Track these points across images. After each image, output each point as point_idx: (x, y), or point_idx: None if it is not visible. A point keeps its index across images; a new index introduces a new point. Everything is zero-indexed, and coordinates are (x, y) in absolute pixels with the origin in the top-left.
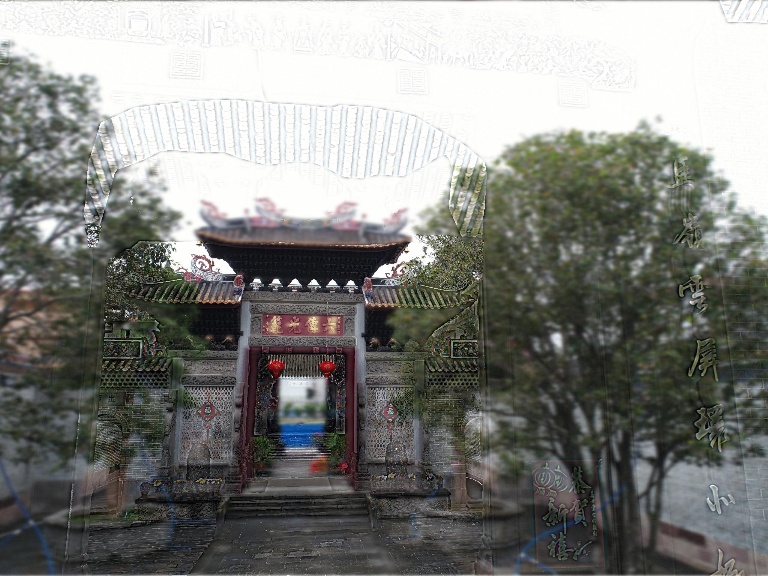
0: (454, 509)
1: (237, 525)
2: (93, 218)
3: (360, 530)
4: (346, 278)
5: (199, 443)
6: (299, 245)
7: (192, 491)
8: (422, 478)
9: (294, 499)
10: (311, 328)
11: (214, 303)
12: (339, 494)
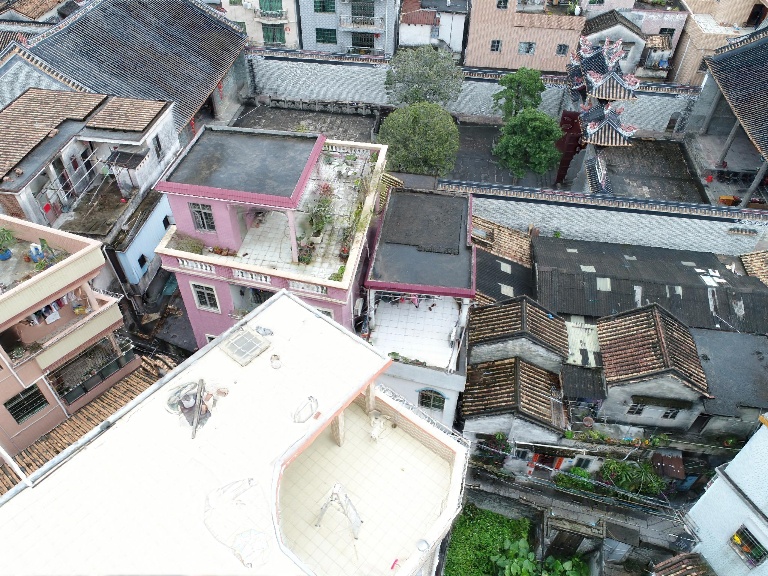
0: None
1: None
2: None
3: None
4: None
5: None
6: None
7: None
8: None
9: None
10: None
11: None
12: None
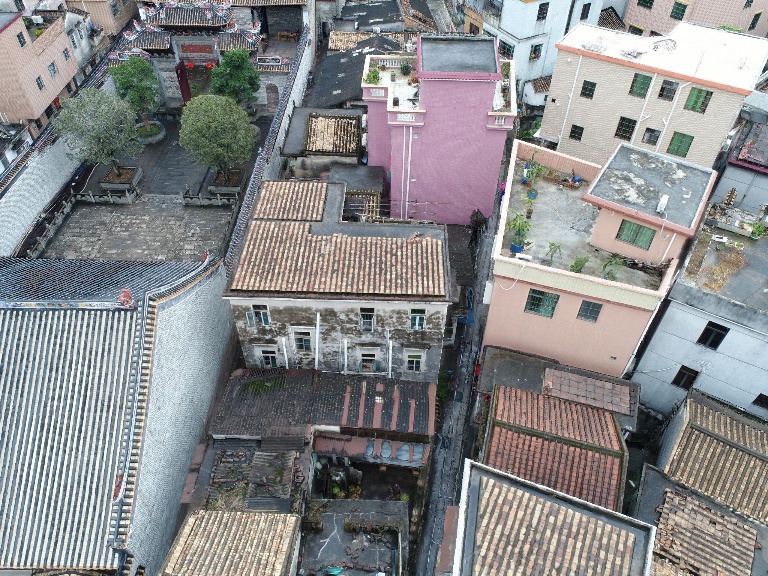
0: None
1: None
2: (258, 5)
3: None
4: None
5: None
6: None
7: None
8: None
9: None
10: None
11: None
12: None
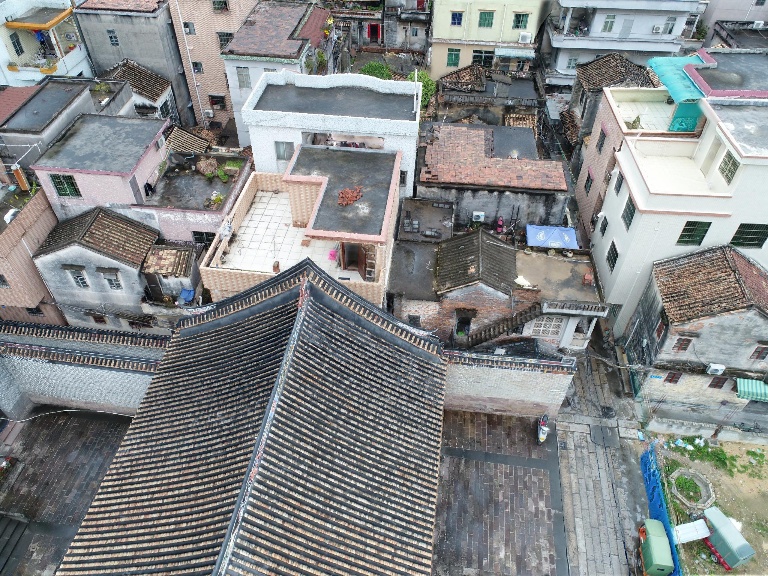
0: (4, 454)
1: None
2: None
3: (24, 530)
4: None
5: None
6: None
7: None
8: (2, 470)
9: None
10: None
11: None
12: None
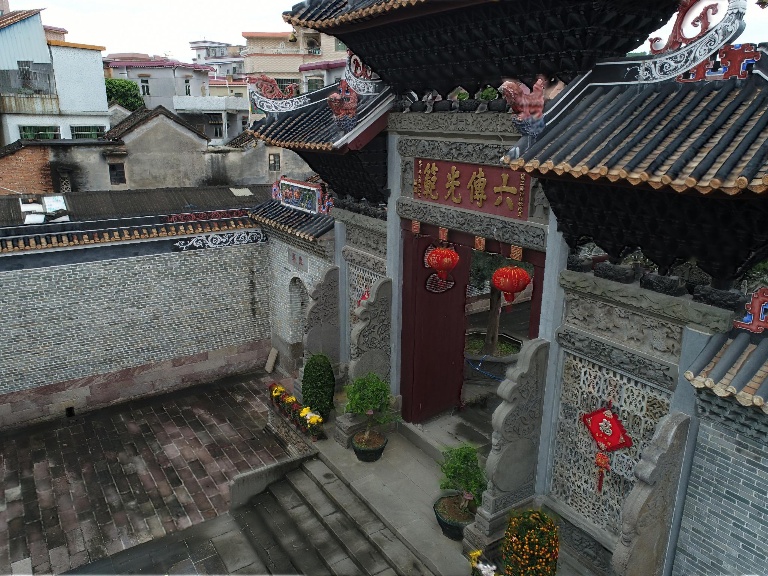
0: None
1: (258, 510)
2: None
3: None
4: (535, 71)
5: (313, 359)
6: (403, 9)
7: (296, 420)
8: None
9: (367, 506)
10: (476, 194)
11: (316, 147)
12: (413, 546)
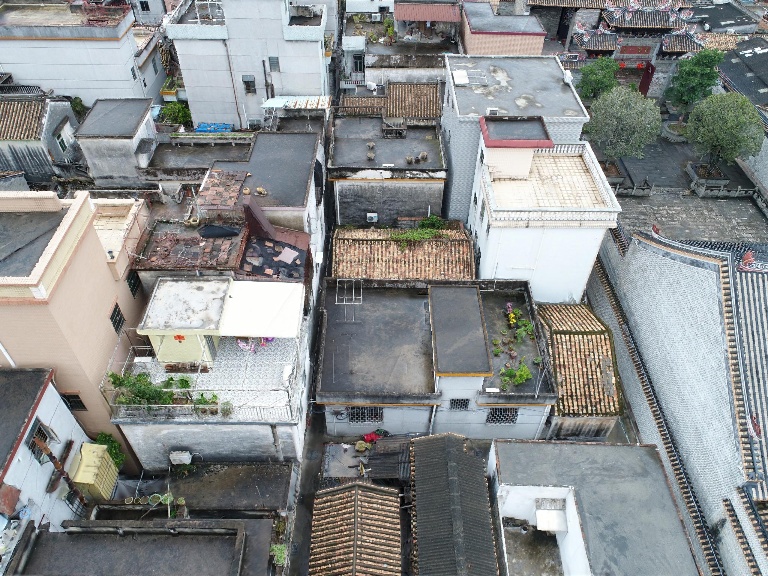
0: None
1: None
2: None
3: None
4: None
5: None
6: None
7: None
8: None
9: None
10: None
11: None
12: None
